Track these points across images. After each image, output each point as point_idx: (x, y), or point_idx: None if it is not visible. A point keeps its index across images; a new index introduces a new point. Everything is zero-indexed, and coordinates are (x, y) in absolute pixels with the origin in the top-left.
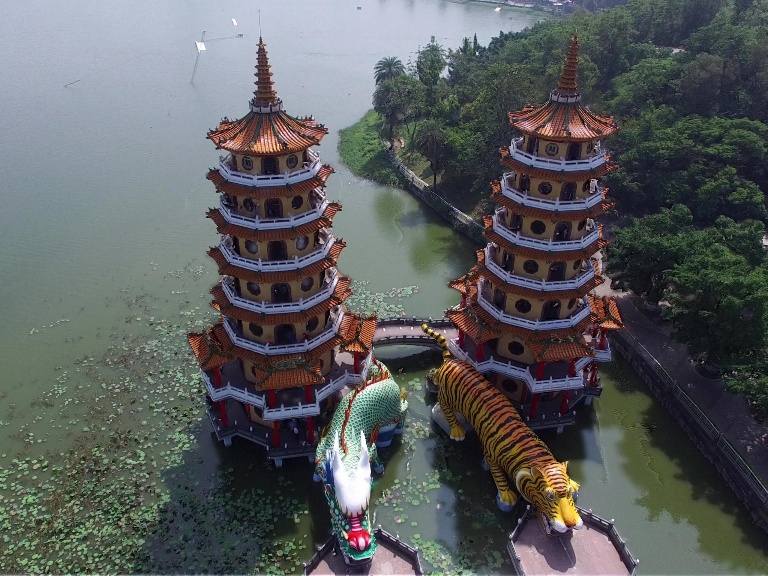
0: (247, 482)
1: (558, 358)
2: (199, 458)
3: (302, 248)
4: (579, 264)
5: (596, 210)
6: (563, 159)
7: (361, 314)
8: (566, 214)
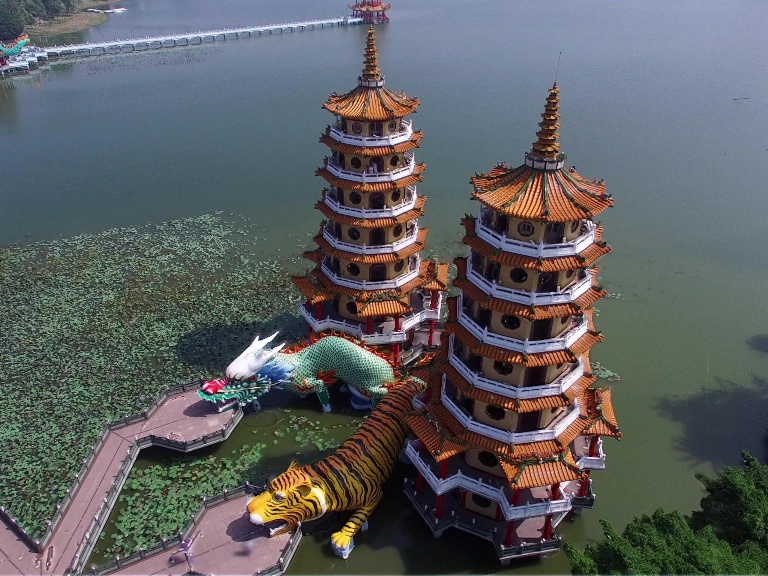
0: (290, 348)
1: (414, 430)
2: (304, 322)
3: (357, 203)
4: (510, 373)
5: (505, 306)
6: (482, 221)
7: (390, 291)
8: (472, 287)
